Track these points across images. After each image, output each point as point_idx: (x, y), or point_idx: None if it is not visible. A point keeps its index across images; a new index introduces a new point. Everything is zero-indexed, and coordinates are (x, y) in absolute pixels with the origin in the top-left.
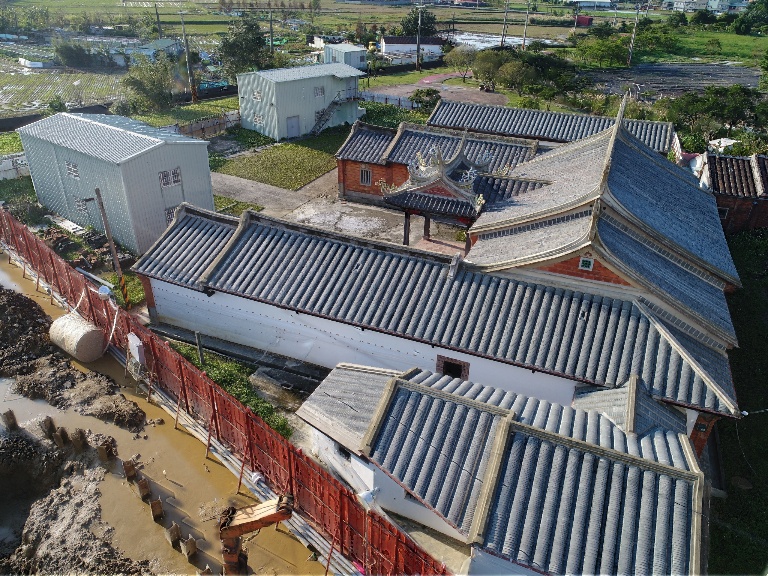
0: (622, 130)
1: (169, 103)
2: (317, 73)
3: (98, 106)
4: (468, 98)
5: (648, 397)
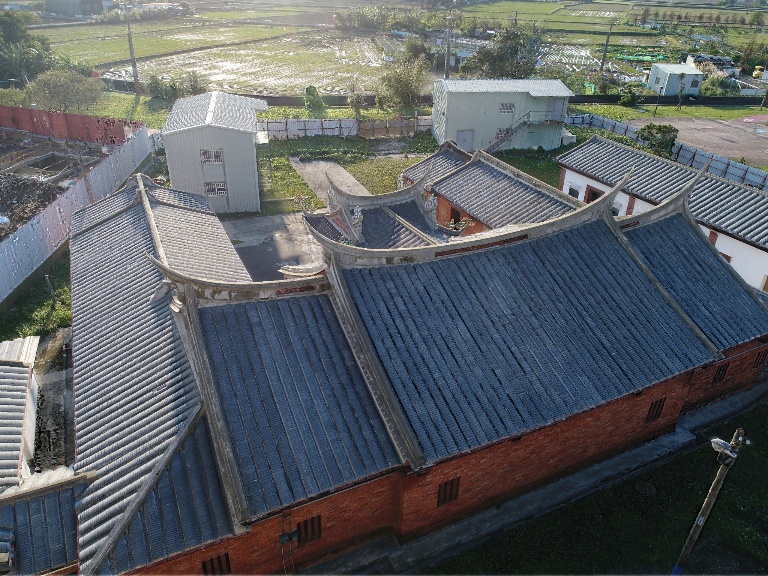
0: (680, 215)
1: (418, 102)
2: (510, 88)
3: (366, 97)
4: (767, 148)
5: (69, 502)
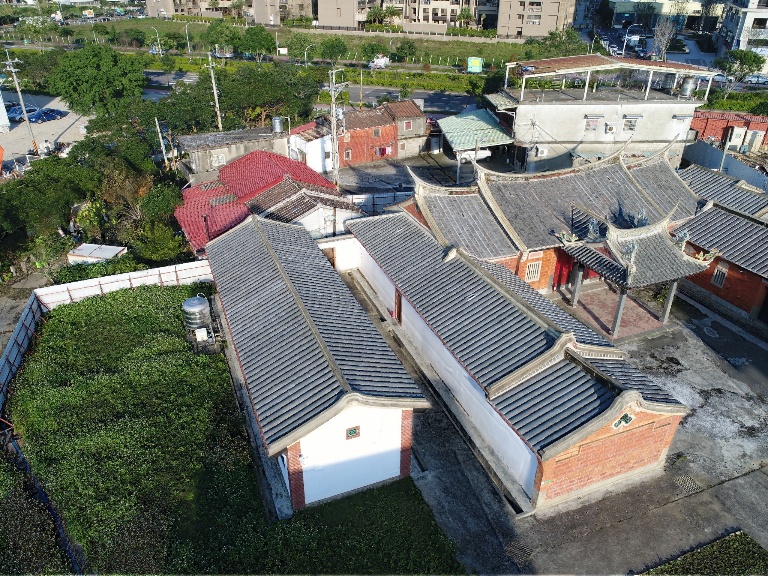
0: None
1: None
2: None
3: None
4: None
5: None
